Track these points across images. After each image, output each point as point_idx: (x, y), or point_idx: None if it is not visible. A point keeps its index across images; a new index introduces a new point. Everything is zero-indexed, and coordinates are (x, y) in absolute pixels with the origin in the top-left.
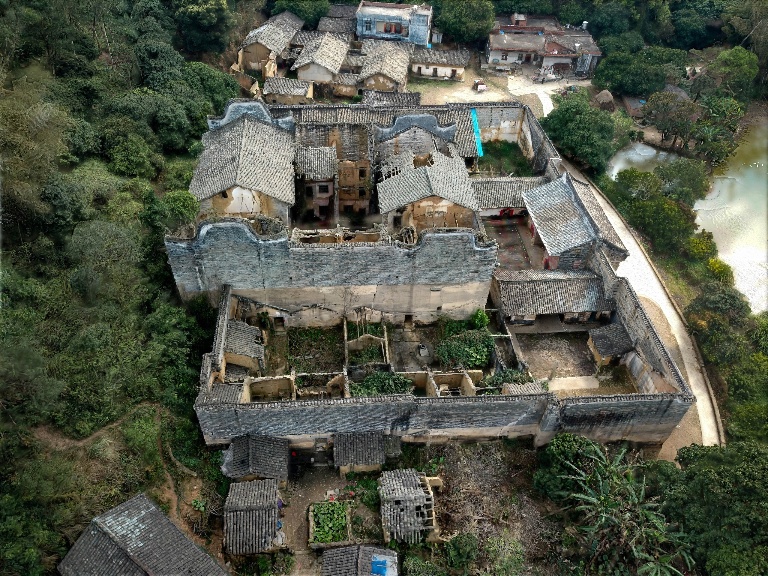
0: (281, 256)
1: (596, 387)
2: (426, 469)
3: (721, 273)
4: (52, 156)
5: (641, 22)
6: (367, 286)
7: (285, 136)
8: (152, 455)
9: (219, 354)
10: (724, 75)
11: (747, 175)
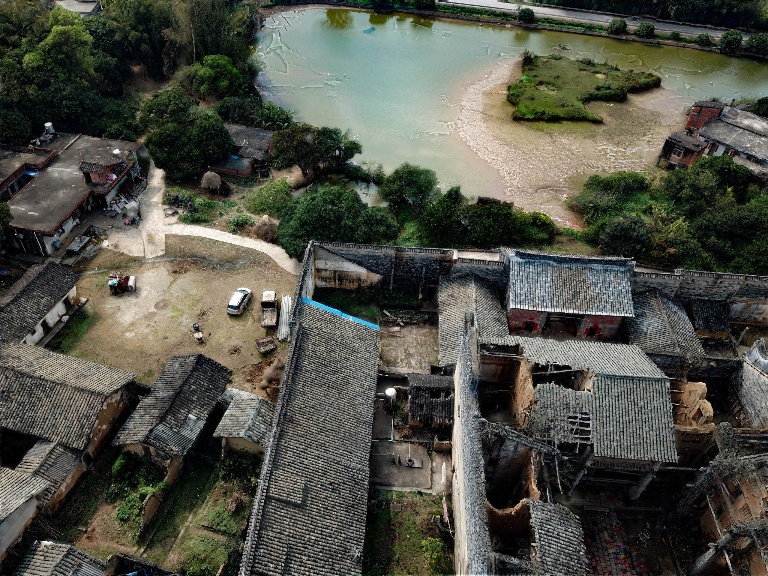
0: None
1: None
2: None
3: None
4: None
5: None
6: None
7: None
8: None
9: None
10: (227, 88)
11: (364, 151)
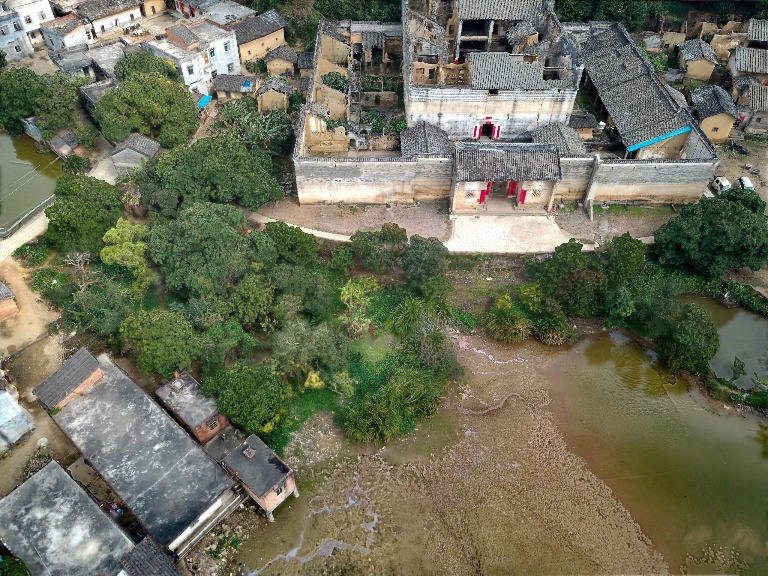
0: None
1: None
2: (296, 105)
3: (499, 313)
4: None
5: None
6: None
7: (538, 12)
8: (313, 32)
9: (353, 24)
10: None
11: None
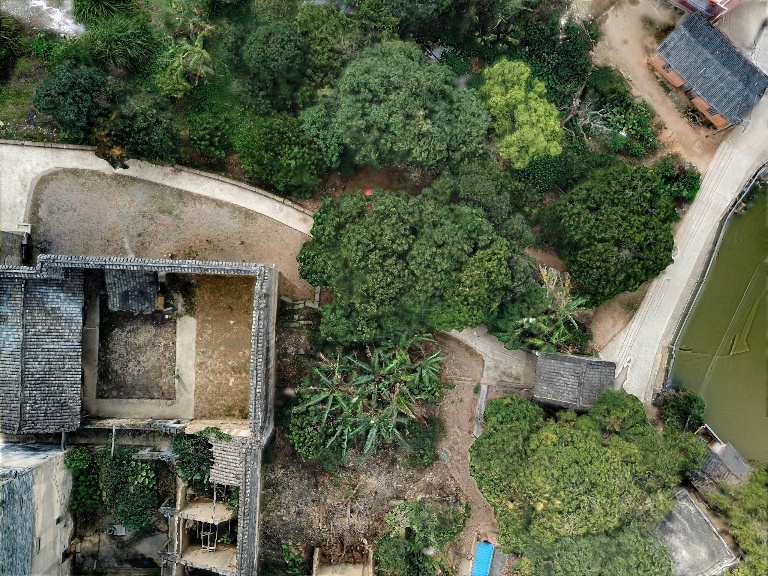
0: None
1: (195, 323)
2: (295, 567)
3: None
4: None
5: None
6: None
7: None
8: None
9: None
10: None
11: None
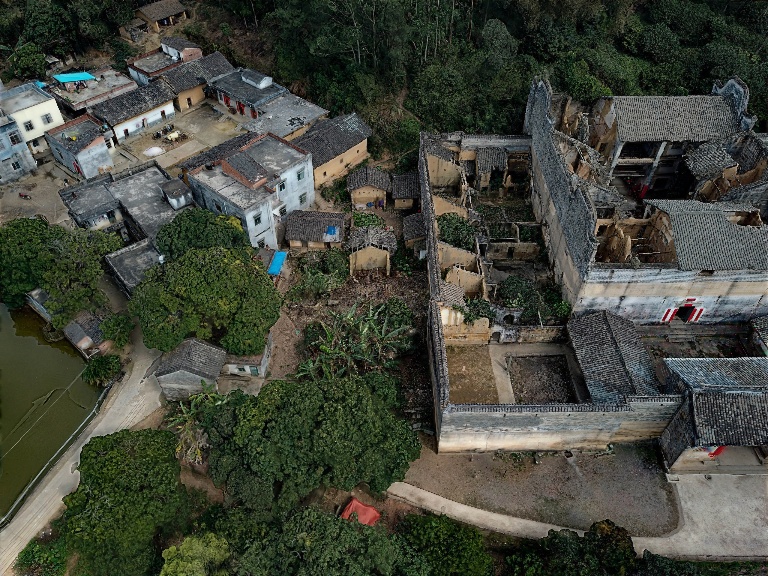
0: None
1: None
2: (402, 263)
3: None
4: (616, 32)
5: None
6: None
7: (729, 130)
8: (405, 141)
9: (465, 139)
10: None
11: None
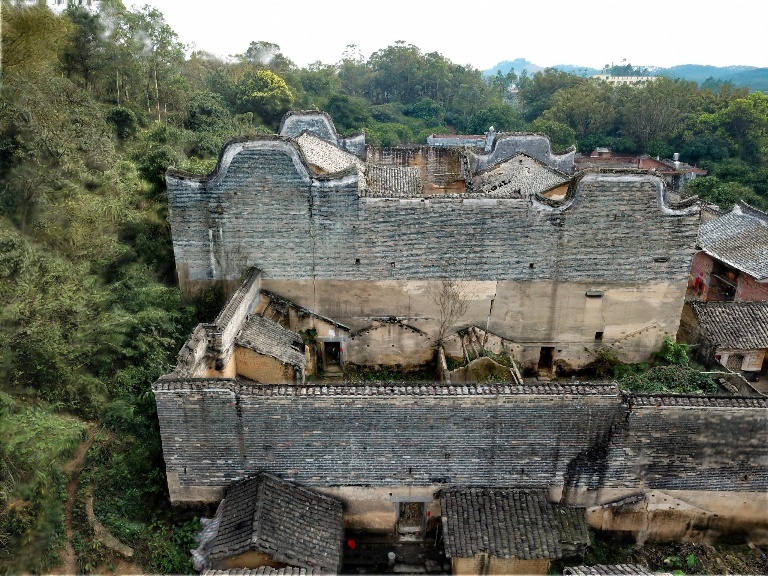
0: (345, 214)
1: None
2: None
3: None
4: None
5: (739, 155)
6: (481, 282)
7: (353, 157)
8: (45, 498)
9: (224, 330)
10: None
11: None
